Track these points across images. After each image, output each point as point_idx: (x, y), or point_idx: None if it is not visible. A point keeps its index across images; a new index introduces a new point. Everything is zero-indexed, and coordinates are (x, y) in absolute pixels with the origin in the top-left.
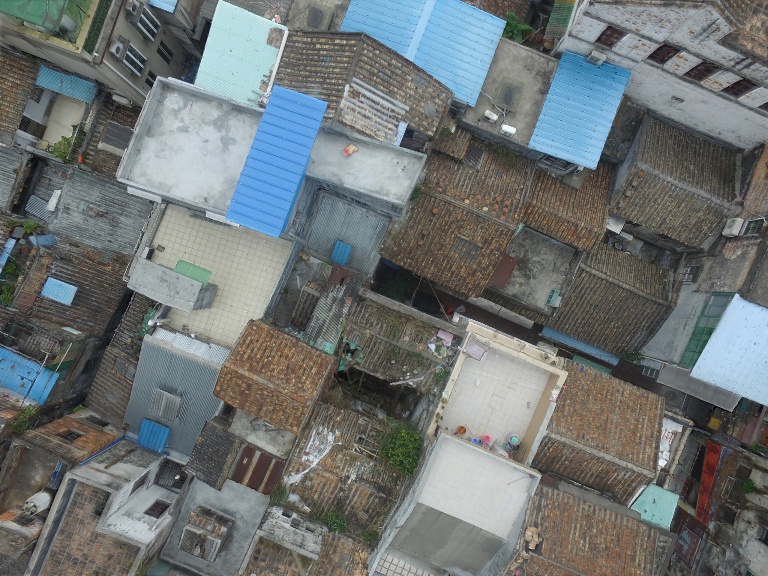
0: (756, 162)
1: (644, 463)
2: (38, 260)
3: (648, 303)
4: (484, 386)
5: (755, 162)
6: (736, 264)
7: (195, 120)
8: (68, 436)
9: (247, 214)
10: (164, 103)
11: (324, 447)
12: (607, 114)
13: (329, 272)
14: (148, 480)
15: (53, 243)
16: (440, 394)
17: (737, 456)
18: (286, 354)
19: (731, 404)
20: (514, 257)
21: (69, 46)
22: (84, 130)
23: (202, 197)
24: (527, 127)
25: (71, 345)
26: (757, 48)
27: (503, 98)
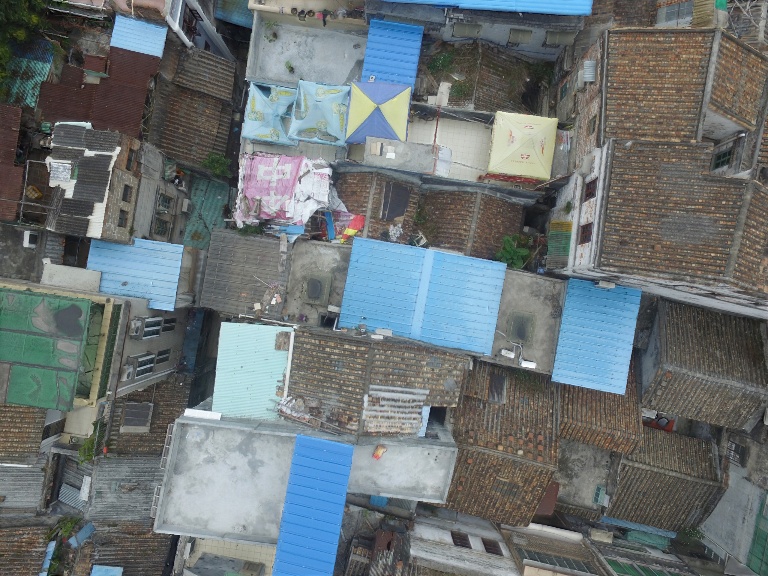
0: None
1: None
2: (80, 552)
3: (698, 485)
4: None
5: None
6: None
7: (219, 449)
8: None
9: (293, 572)
10: (186, 438)
11: None
12: (626, 337)
13: (371, 518)
14: None
15: (92, 531)
16: None
17: None
18: None
19: None
20: None
21: (83, 402)
22: (104, 422)
23: (240, 525)
24: (545, 354)
25: None
26: None
27: (517, 333)
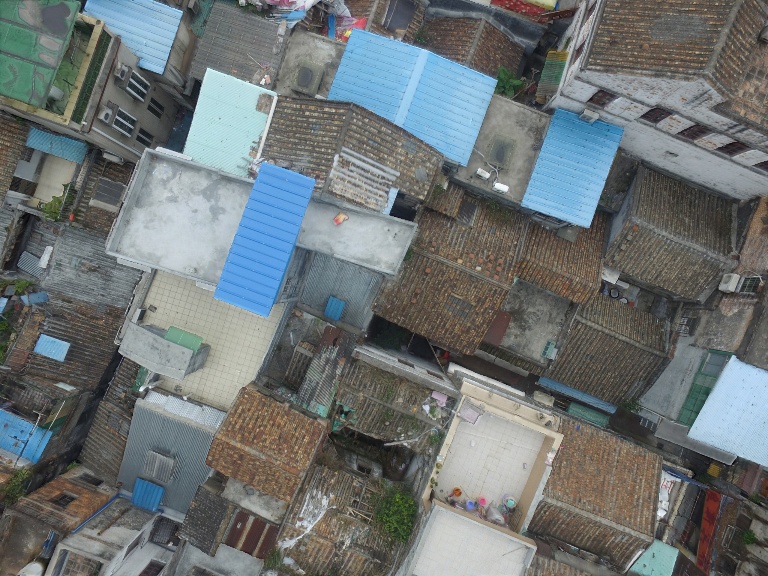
0: (752, 215)
1: (642, 526)
2: (30, 317)
3: (645, 354)
4: (479, 447)
5: (751, 215)
6: (733, 322)
7: (184, 190)
8: (61, 501)
9: (236, 293)
10: (153, 173)
11: (318, 512)
12: (600, 172)
13: (322, 328)
14: (142, 539)
15: (45, 300)
16: (435, 456)
17: (737, 504)
18: (278, 423)
19: (730, 458)
20: (509, 308)
21: (57, 118)
22: (75, 188)
23: (192, 267)
24: (520, 184)
25: (64, 403)
26: (750, 114)
27: (495, 156)
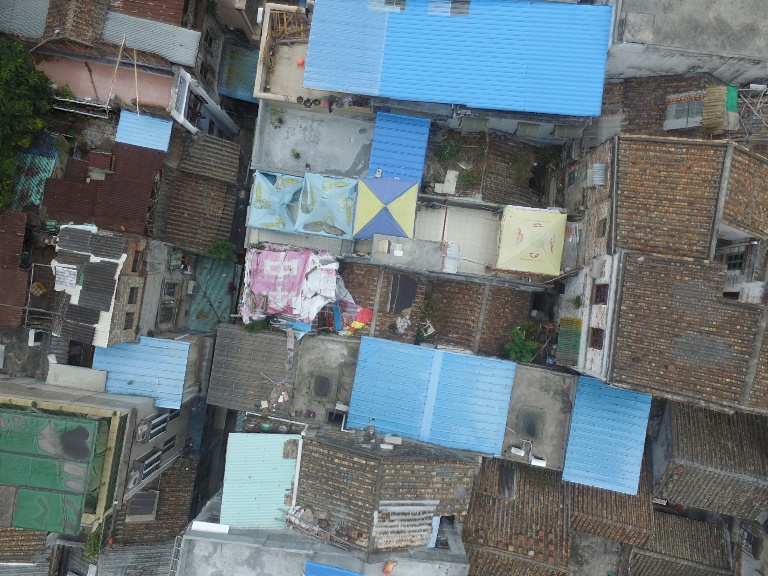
0: None
1: None
2: None
3: (710, 573)
4: None
5: None
6: None
7: (227, 562)
8: None
9: None
10: (193, 552)
11: None
12: (637, 436)
13: None
14: None
15: None
16: None
17: None
18: None
19: None
20: None
21: (90, 517)
22: (110, 514)
23: None
24: (556, 449)
25: None
26: None
27: (526, 431)
